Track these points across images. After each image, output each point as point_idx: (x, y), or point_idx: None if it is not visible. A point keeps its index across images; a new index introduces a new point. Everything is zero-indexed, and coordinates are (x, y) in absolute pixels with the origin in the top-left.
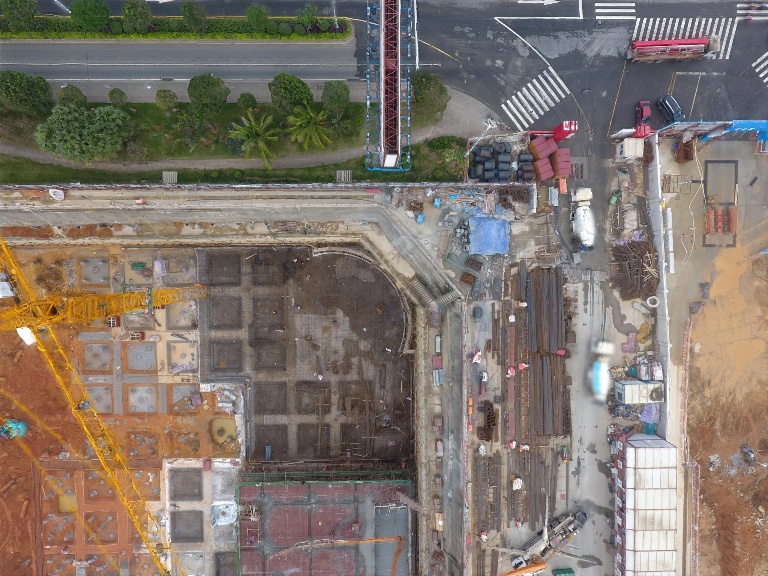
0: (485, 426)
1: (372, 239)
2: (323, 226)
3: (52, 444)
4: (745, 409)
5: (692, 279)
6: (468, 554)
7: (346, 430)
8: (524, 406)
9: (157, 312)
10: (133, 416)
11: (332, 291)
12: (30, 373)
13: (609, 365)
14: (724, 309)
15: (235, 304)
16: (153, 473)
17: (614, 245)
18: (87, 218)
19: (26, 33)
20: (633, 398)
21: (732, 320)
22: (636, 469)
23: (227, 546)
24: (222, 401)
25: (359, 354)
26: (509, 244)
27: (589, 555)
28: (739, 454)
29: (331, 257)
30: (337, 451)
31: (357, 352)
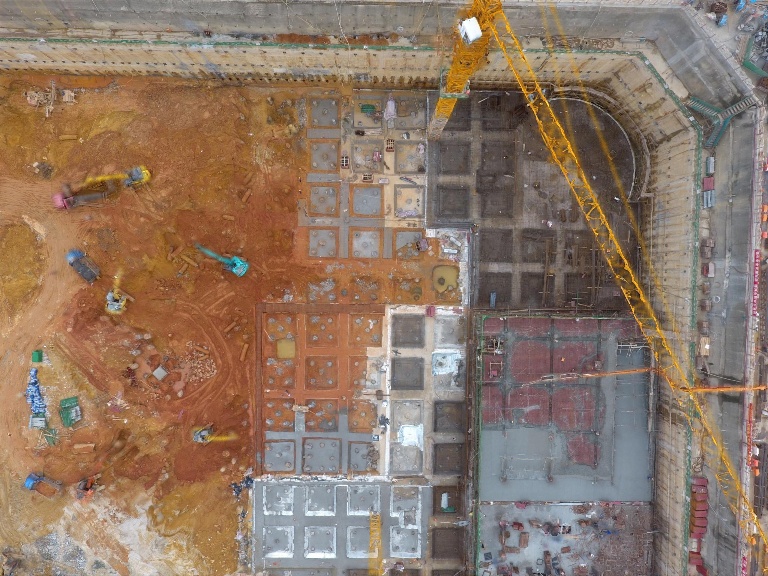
0: None
1: (647, 57)
2: (598, 43)
3: (277, 286)
4: None
5: None
6: None
7: (571, 279)
8: None
9: (386, 155)
10: (357, 260)
11: None
12: (258, 213)
13: None
14: None
15: (462, 150)
16: (374, 319)
17: None
18: (379, 18)
19: None
20: None
21: None
22: None
23: (447, 395)
24: (446, 248)
25: None
26: None
27: None
28: None
29: (563, 103)
30: (562, 300)
31: None
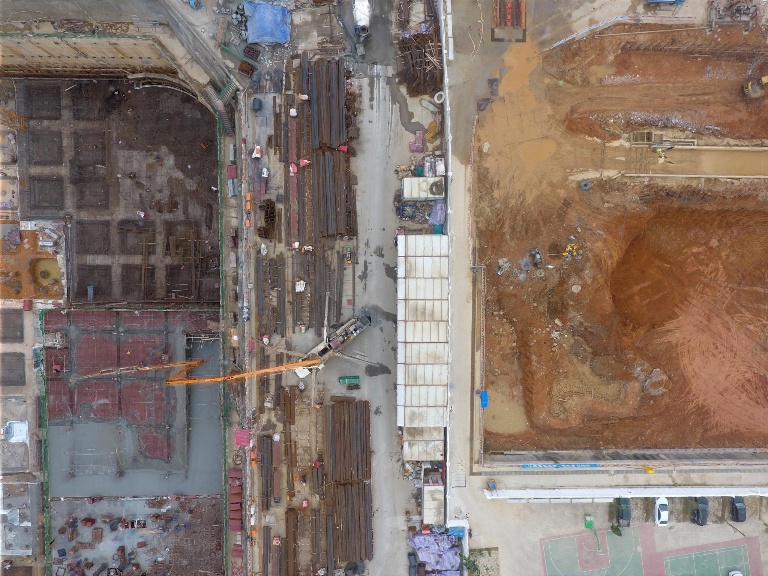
0: (265, 224)
1: (164, 42)
2: (112, 27)
3: None
4: (535, 212)
5: (480, 75)
6: (251, 359)
7: (171, 271)
8: (308, 206)
9: None
10: None
11: (155, 126)
12: None
13: (396, 165)
14: (513, 107)
15: (57, 140)
16: None
17: (400, 38)
18: None
19: None
20: (412, 191)
21: (522, 119)
22: (406, 257)
23: None
24: (44, 240)
25: (184, 193)
26: (290, 34)
27: (377, 363)
28: (528, 258)
29: (154, 90)
30: (162, 293)
31: (183, 191)
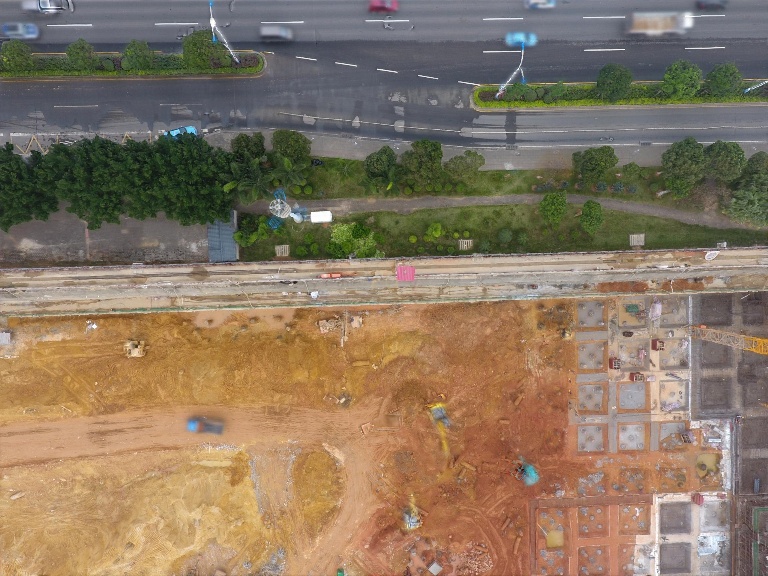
0: None
1: None
2: None
3: (551, 483)
4: None
5: None
6: None
7: None
8: None
9: (651, 353)
10: (625, 454)
11: None
12: (530, 415)
13: None
14: None
15: None
16: (641, 508)
17: None
18: None
19: (688, 99)
20: None
21: None
22: None
23: (713, 575)
24: (709, 437)
25: None
26: None
27: None
28: None
29: None
30: None
31: None
